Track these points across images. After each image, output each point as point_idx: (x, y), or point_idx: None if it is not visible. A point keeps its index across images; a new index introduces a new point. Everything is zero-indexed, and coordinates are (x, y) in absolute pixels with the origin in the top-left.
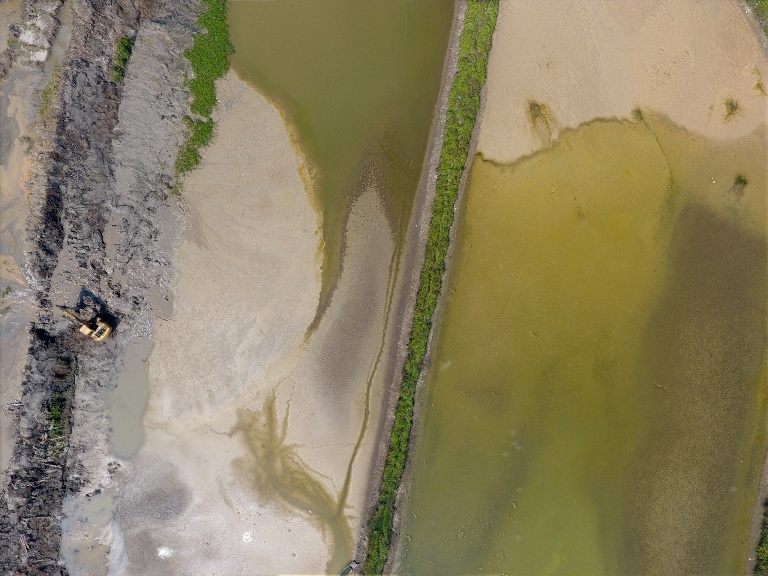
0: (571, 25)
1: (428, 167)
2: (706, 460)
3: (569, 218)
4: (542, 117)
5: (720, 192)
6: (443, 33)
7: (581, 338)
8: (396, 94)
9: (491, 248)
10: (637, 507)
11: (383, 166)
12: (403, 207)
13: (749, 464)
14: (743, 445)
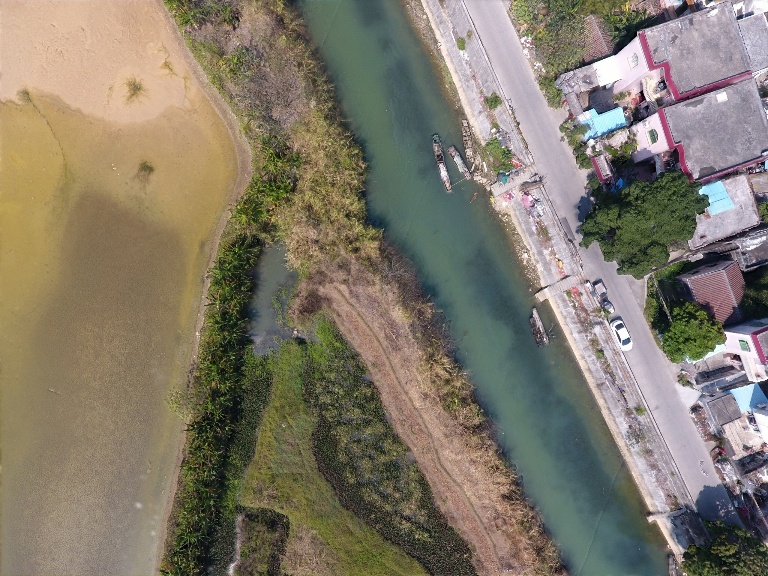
0: None
1: None
2: (107, 470)
3: None
4: None
5: (122, 179)
6: None
7: None
8: None
9: None
10: (26, 522)
11: None
12: None
13: (158, 474)
14: (151, 454)
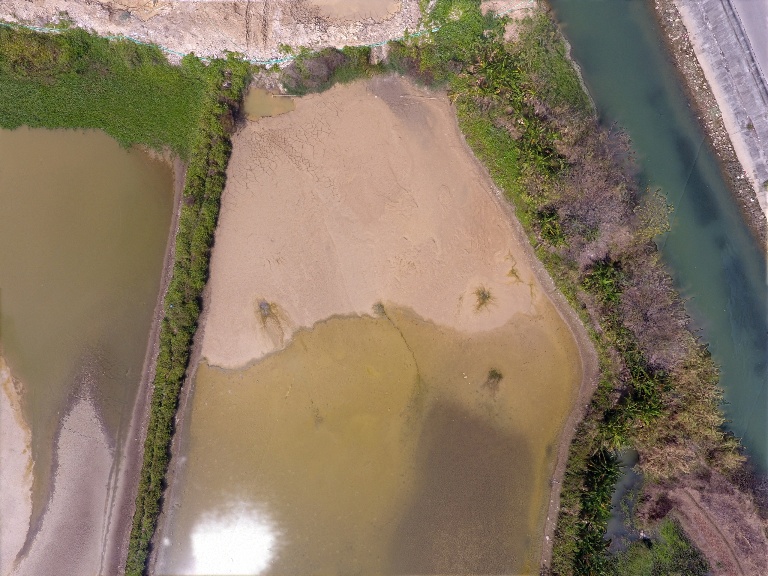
0: (303, 216)
1: (147, 375)
2: None
3: (306, 423)
4: (273, 316)
5: (473, 388)
6: (162, 230)
7: (322, 551)
8: (111, 298)
9: (220, 459)
10: None
11: (97, 376)
12: (121, 420)
13: None
14: None
